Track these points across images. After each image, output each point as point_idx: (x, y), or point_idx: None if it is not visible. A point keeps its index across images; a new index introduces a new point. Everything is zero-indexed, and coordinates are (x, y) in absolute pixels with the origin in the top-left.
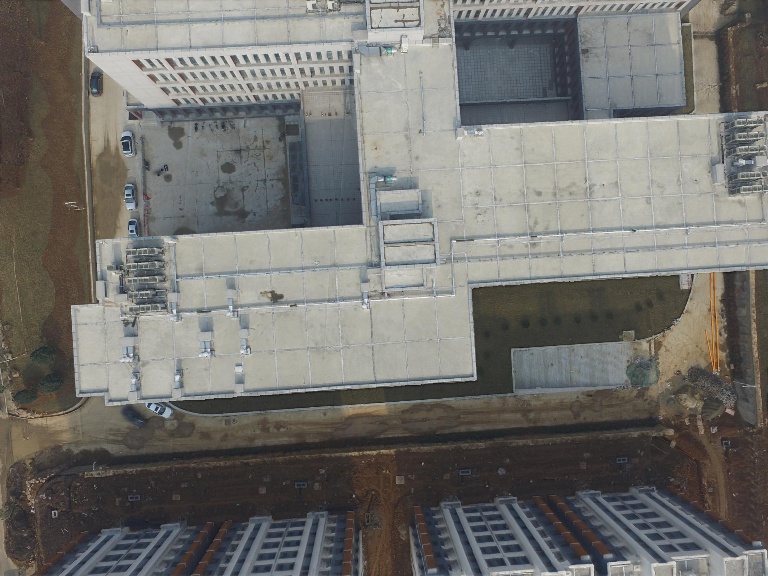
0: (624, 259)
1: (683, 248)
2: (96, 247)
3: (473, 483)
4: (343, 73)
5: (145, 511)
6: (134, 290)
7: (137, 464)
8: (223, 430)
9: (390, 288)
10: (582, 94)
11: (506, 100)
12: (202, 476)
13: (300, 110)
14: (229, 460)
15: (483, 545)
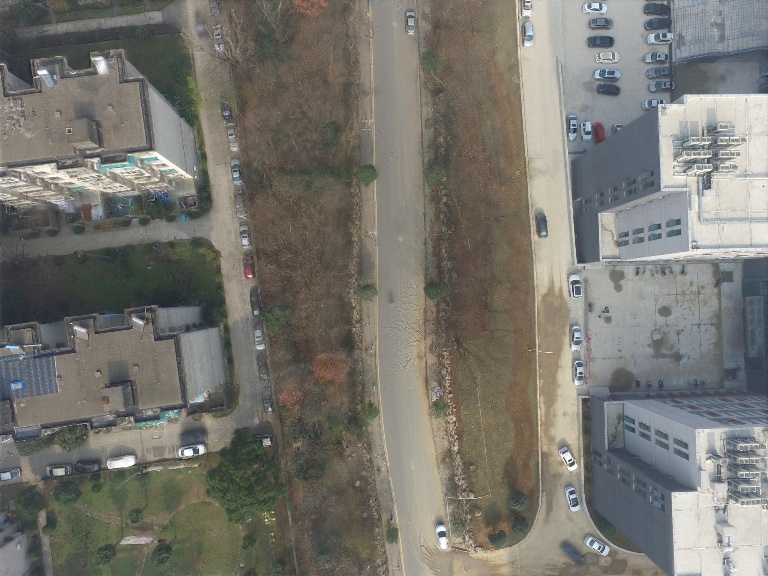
0: None
1: None
2: (696, 436)
3: None
4: None
5: None
6: (725, 477)
7: None
8: (654, 568)
9: None
10: None
11: None
12: None
13: None
14: None
15: None
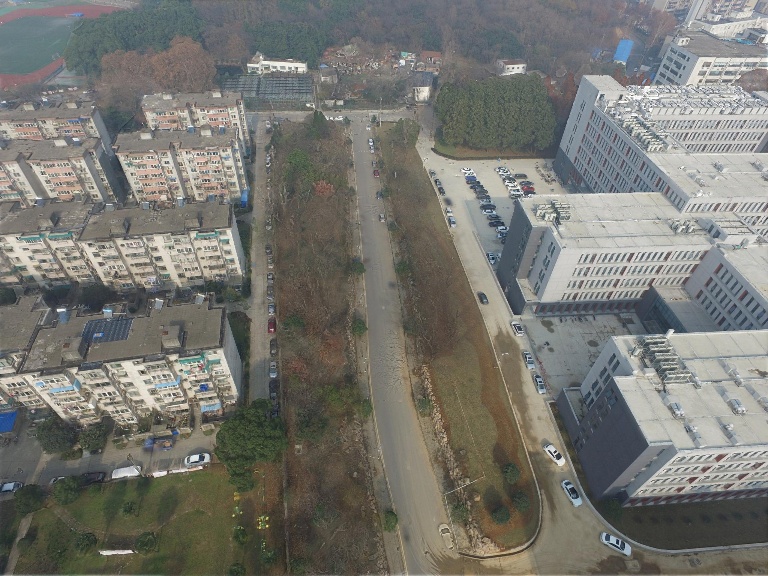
0: None
1: None
2: (613, 340)
3: None
4: (685, 272)
5: None
6: None
7: None
8: (691, 573)
9: None
10: None
11: None
12: None
13: (659, 295)
14: None
15: None
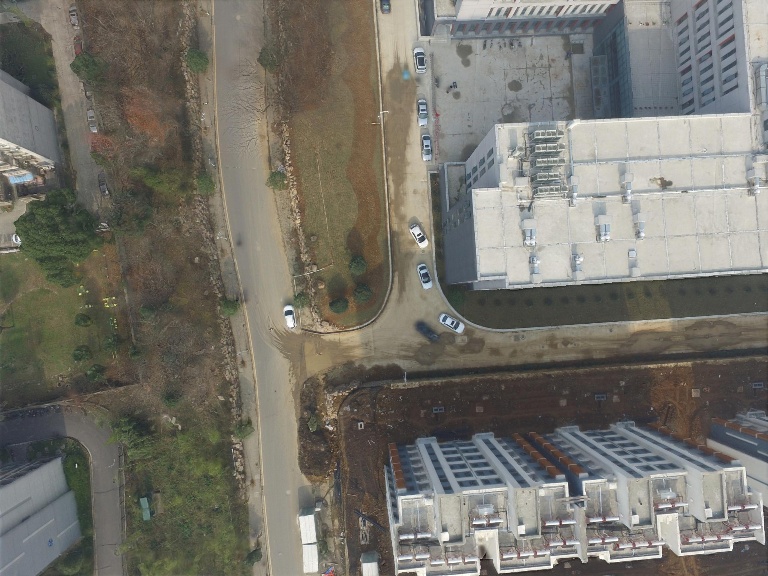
0: None
1: None
2: (495, 131)
3: (765, 396)
4: None
5: (449, 423)
6: None
7: (435, 378)
8: (512, 346)
9: None
10: None
11: None
12: (506, 388)
13: (624, 18)
14: (530, 372)
15: None
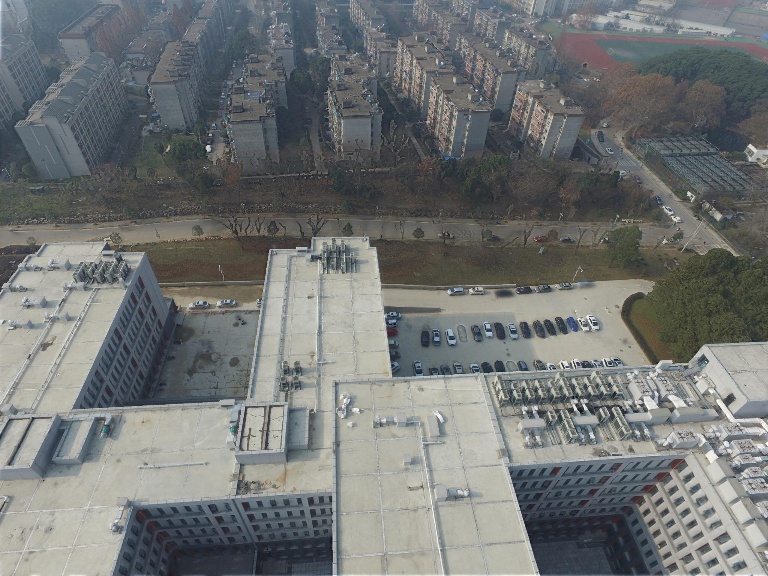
0: None
1: None
2: None
3: None
4: None
5: None
6: None
7: None
8: None
9: None
10: None
11: None
12: None
13: (244, 394)
14: None
15: None
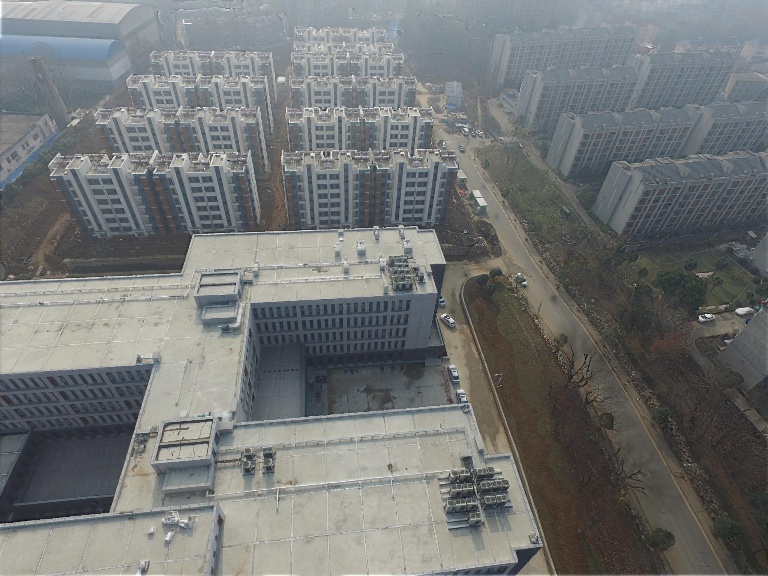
0: (58, 289)
1: (7, 294)
2: None
3: None
4: None
5: None
6: None
7: None
8: None
9: (238, 269)
10: (4, 489)
11: (91, 498)
12: None
13: None
14: None
15: (213, 194)
